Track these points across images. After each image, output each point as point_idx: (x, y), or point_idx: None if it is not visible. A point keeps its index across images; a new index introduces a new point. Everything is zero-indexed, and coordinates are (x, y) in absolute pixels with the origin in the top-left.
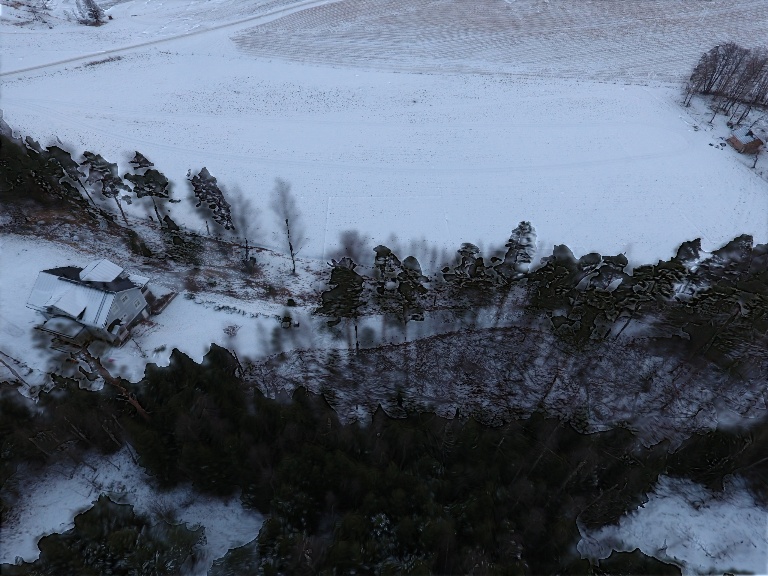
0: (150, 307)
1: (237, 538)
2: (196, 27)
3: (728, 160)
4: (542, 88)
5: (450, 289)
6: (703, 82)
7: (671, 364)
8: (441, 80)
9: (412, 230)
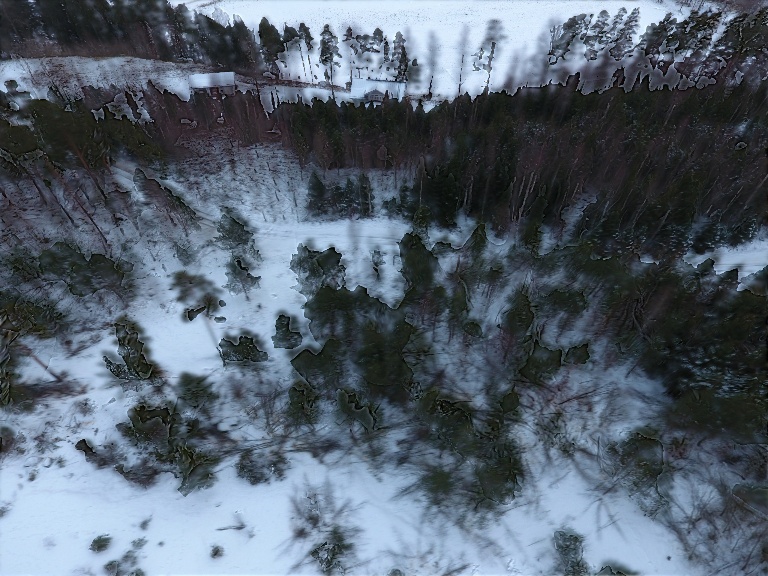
0: None
1: None
2: None
3: None
4: None
5: None
6: None
7: None
8: (477, 0)
9: (513, 79)
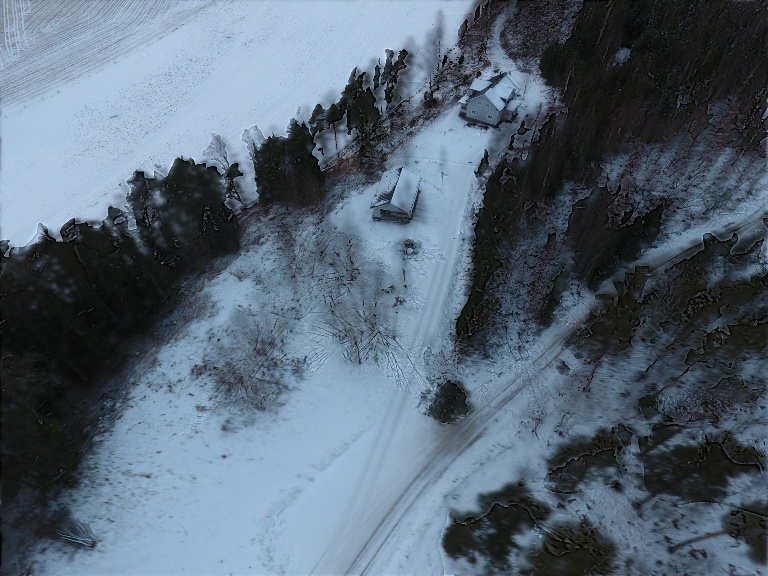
0: None
1: (628, 53)
2: None
3: None
4: None
5: (464, 48)
6: None
7: (535, 2)
8: (200, 22)
9: None
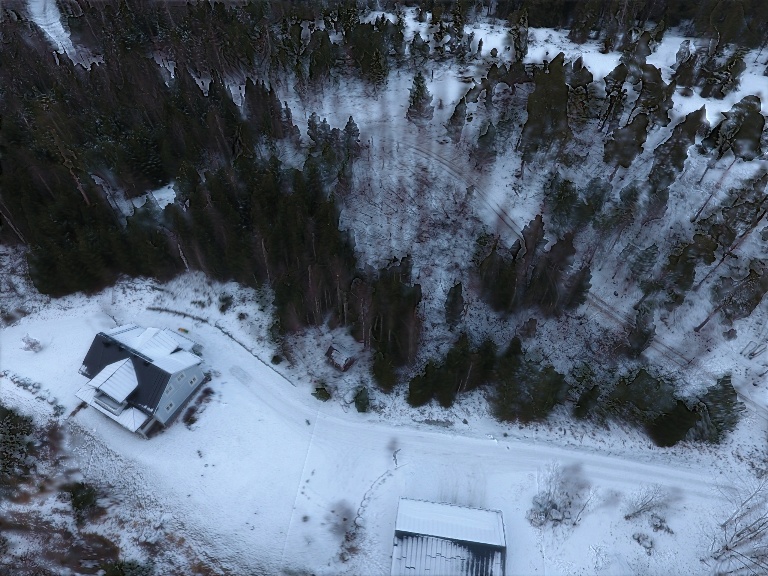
0: None
1: None
2: None
3: None
4: None
5: None
6: None
7: None
8: None
9: None
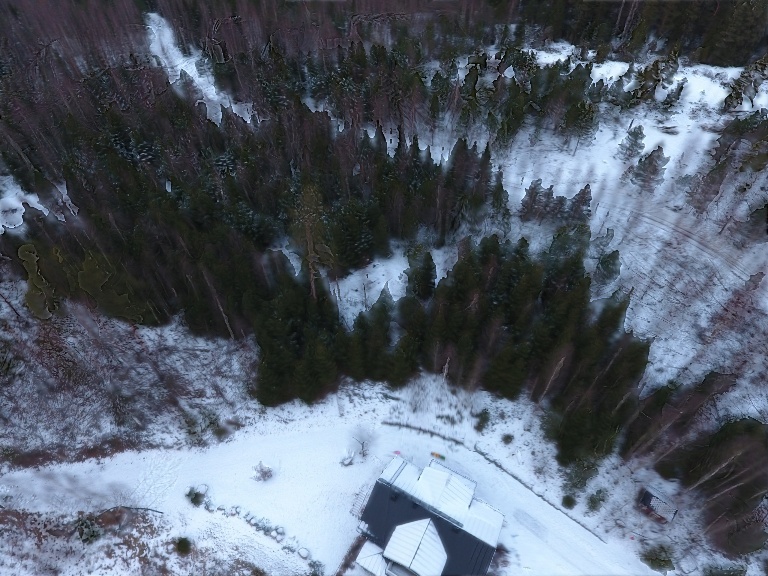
0: None
1: None
2: None
3: None
4: None
5: None
6: None
7: None
8: None
9: None
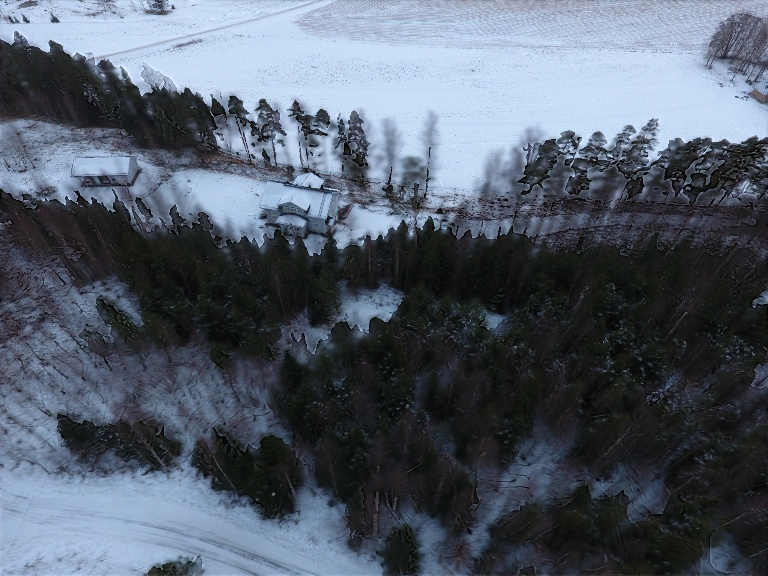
0: (338, 213)
1: (491, 326)
2: (258, 13)
3: (753, 108)
4: (581, 57)
5: None
6: (721, 48)
7: (746, 239)
8: (490, 53)
9: (506, 166)
